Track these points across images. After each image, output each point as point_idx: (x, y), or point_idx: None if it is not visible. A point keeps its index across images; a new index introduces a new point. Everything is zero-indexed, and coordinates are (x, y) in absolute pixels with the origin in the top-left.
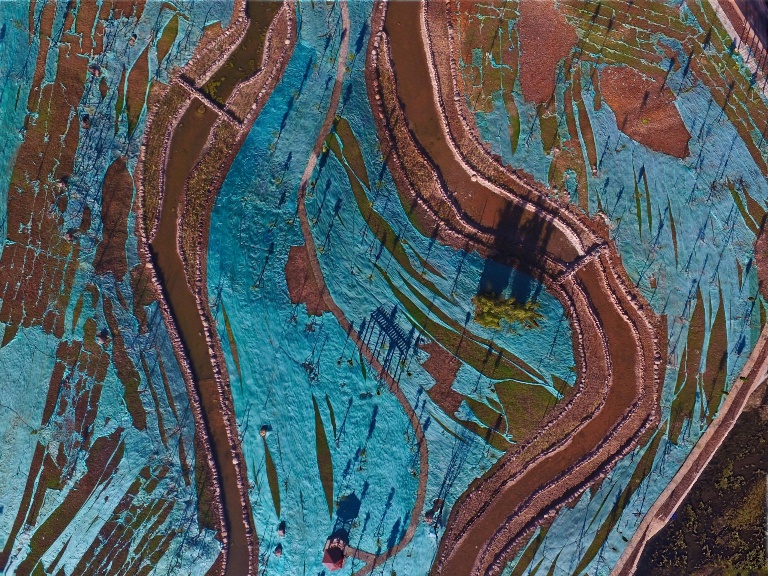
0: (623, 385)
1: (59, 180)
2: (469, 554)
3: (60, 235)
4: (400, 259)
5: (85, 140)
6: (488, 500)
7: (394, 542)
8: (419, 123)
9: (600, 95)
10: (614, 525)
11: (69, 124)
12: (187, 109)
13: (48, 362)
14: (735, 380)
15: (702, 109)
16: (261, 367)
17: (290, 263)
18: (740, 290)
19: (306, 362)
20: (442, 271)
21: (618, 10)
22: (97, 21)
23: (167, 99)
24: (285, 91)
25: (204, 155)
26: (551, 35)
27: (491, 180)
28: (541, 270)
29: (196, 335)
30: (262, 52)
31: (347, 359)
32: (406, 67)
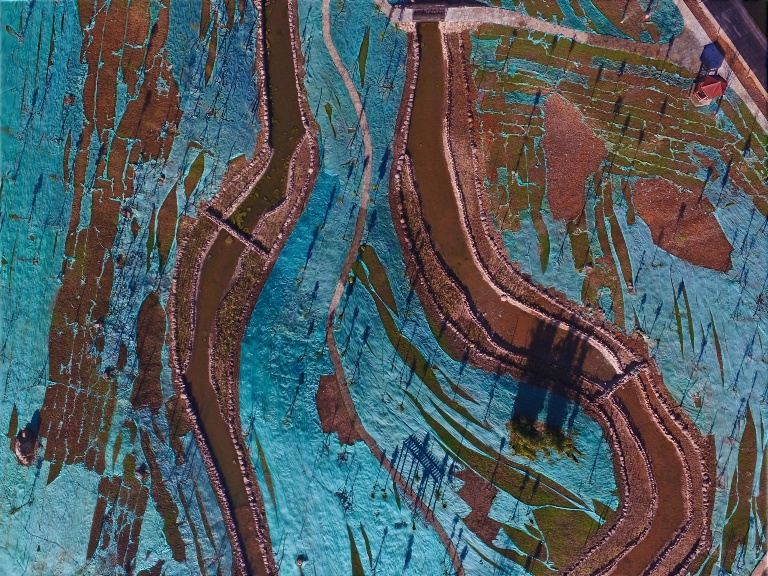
0: (669, 507)
1: (96, 321)
2: None
3: (98, 374)
4: (431, 385)
5: (119, 280)
6: None
7: None
8: (445, 244)
9: (633, 209)
10: None
11: (104, 266)
12: (215, 240)
13: (91, 498)
14: None
15: (744, 219)
16: (295, 496)
17: (321, 392)
18: None
19: (340, 491)
20: (474, 396)
21: (649, 121)
22: (127, 165)
23: (196, 232)
24: (310, 220)
25: (233, 285)
26: (579, 150)
27: (521, 300)
28: (577, 391)
29: (231, 463)
30: (286, 181)
31: (381, 488)
32: (430, 188)
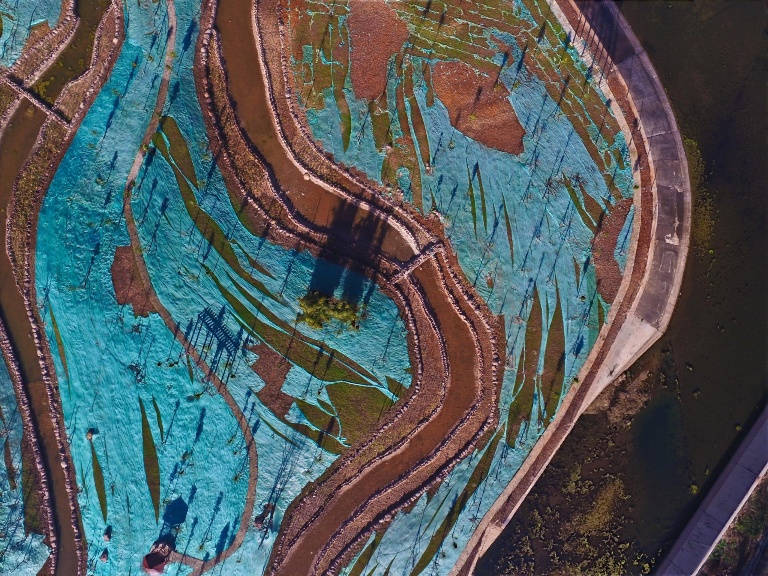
0: (462, 387)
1: None
2: (304, 560)
3: None
4: (229, 259)
5: None
6: (322, 505)
7: (223, 547)
8: (251, 121)
9: (432, 91)
10: (449, 531)
11: None
12: (17, 109)
13: None
14: (573, 382)
15: (537, 104)
16: (88, 369)
17: (116, 263)
18: (578, 289)
19: (133, 364)
20: (272, 271)
21: (450, 4)
22: None
23: None
24: (112, 90)
25: (33, 155)
26: (382, 31)
27: (323, 178)
28: (374, 270)
29: (26, 337)
30: (91, 51)
31: (174, 361)
32: (237, 65)
